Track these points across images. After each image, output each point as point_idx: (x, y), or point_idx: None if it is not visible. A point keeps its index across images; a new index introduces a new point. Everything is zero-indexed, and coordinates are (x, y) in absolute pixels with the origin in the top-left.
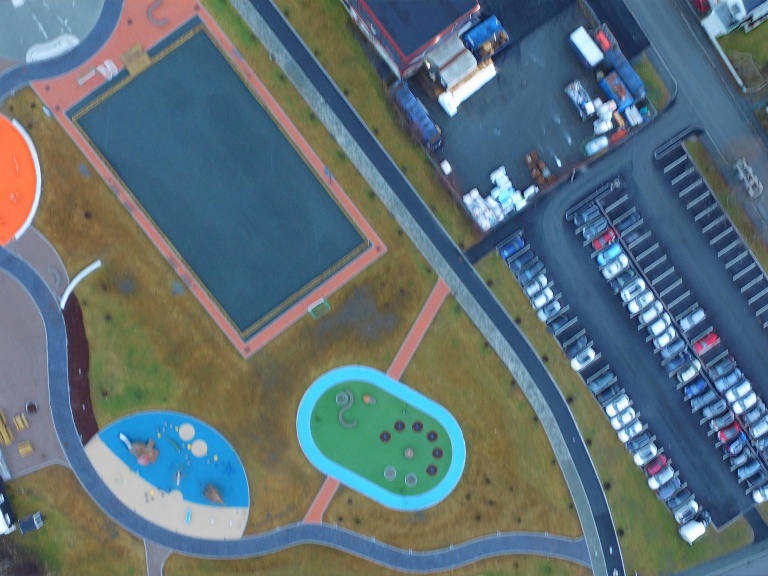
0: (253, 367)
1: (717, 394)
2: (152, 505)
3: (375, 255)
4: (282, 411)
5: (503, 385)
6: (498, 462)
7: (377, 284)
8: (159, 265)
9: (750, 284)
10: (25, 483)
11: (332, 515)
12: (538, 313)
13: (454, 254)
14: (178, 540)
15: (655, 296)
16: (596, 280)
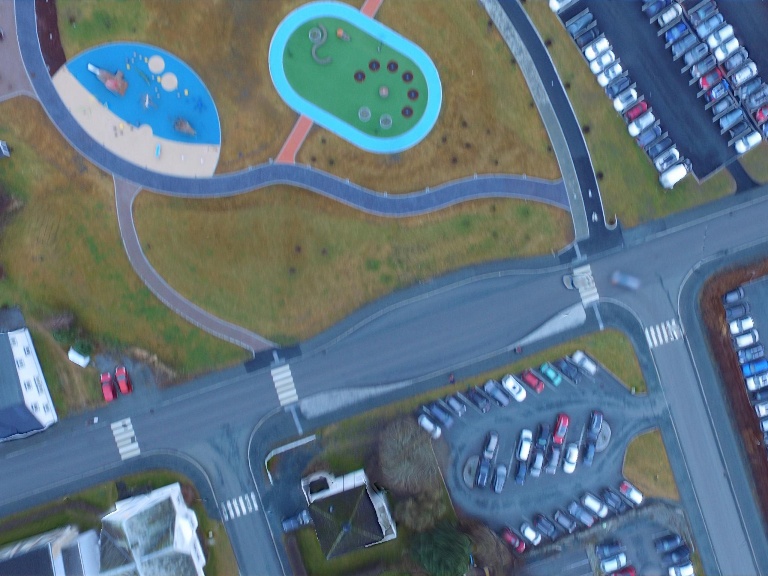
0: None
1: (699, 41)
2: (121, 139)
3: None
4: (254, 46)
5: (480, 25)
6: (475, 104)
7: None
8: None
9: None
10: None
11: (305, 155)
12: None
13: None
14: (148, 176)
15: None
16: None
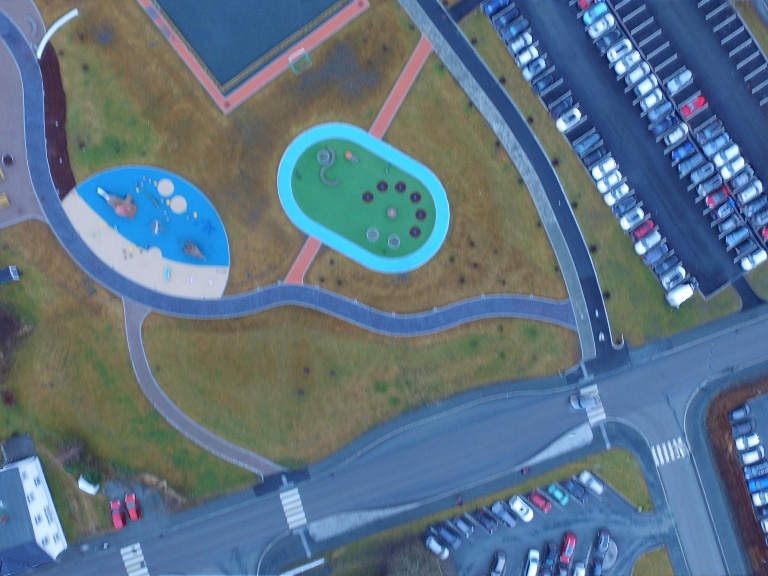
0: (233, 123)
1: (705, 159)
2: (130, 262)
3: (357, 10)
4: (263, 168)
5: (487, 146)
6: (482, 224)
7: (359, 40)
8: (137, 16)
9: (738, 48)
10: (1, 238)
11: (314, 276)
12: (523, 71)
13: (438, 11)
14: (157, 298)
15: (642, 58)
16: (582, 41)
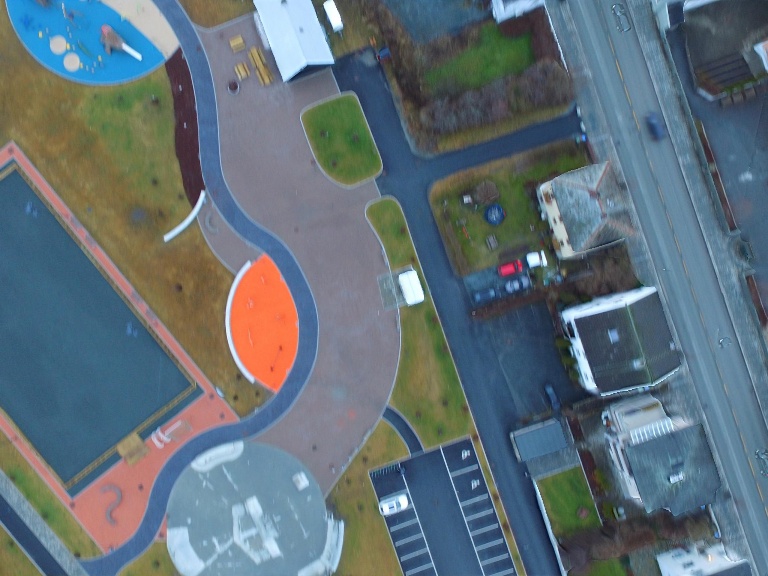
0: (5, 132)
1: None
2: None
3: None
4: None
5: None
6: None
7: None
8: (106, 238)
9: None
10: (240, 8)
11: None
12: None
13: None
14: None
15: None
16: None
